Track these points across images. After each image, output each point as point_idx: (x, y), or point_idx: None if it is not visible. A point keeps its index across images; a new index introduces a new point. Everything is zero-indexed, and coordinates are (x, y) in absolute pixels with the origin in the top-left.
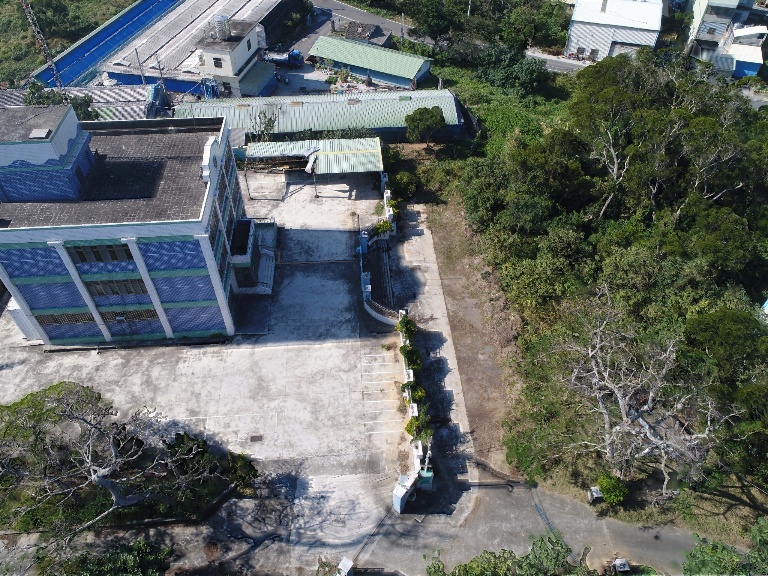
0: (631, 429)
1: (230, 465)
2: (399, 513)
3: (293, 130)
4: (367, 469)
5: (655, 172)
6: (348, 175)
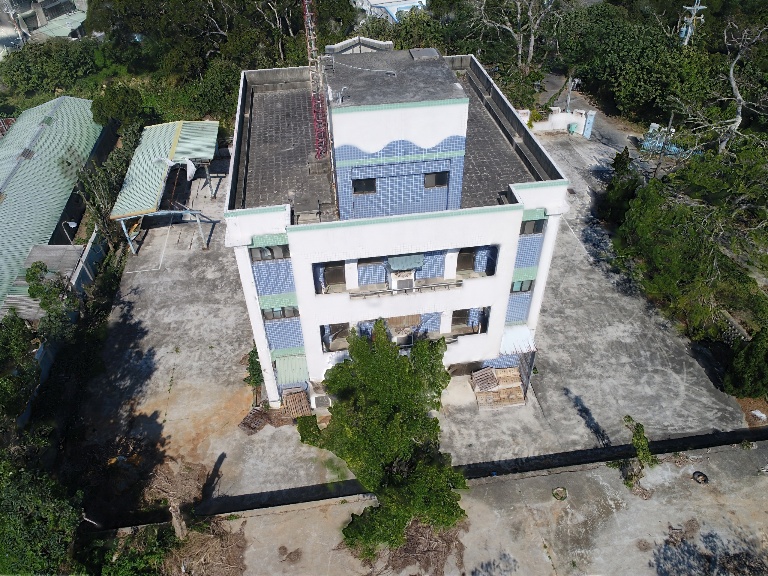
0: (547, 8)
1: (626, 162)
2: (590, 138)
3: (60, 209)
4: (568, 145)
5: (279, 8)
6: (173, 180)
